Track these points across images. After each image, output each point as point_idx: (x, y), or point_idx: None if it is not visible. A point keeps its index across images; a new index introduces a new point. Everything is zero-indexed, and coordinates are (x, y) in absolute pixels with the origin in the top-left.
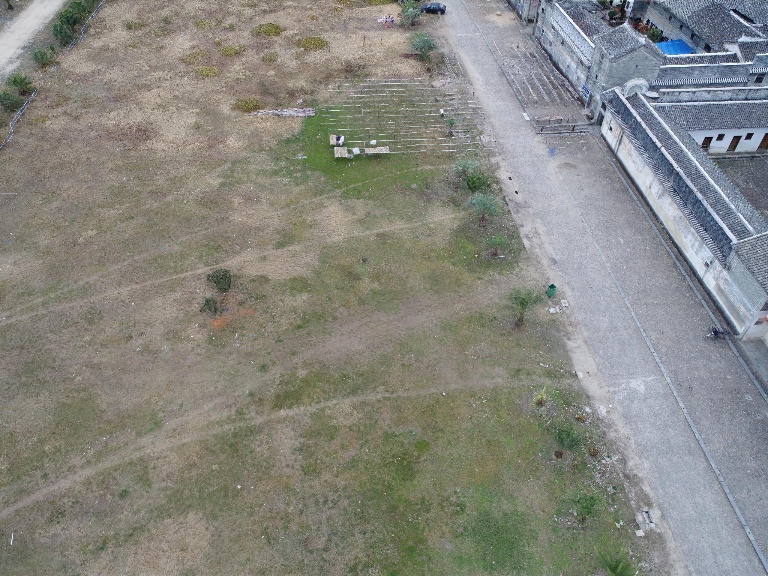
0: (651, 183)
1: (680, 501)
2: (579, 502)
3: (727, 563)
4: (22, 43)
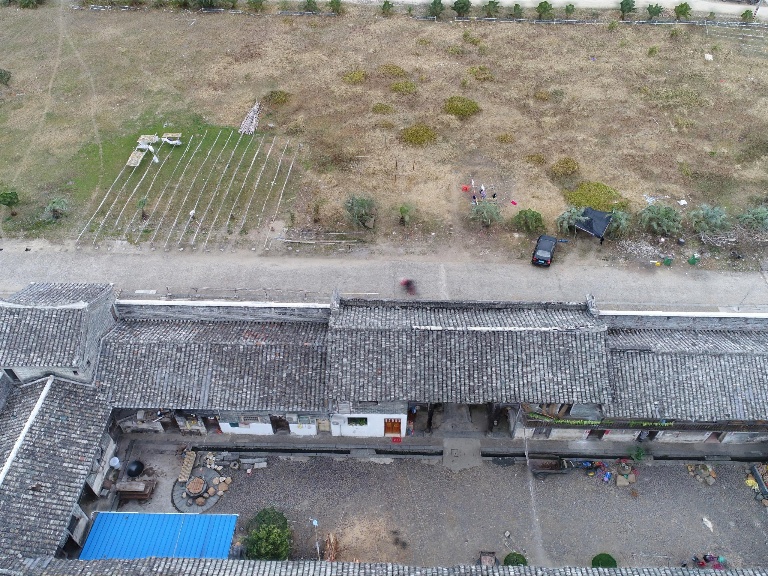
0: None
1: None
2: None
3: None
4: None
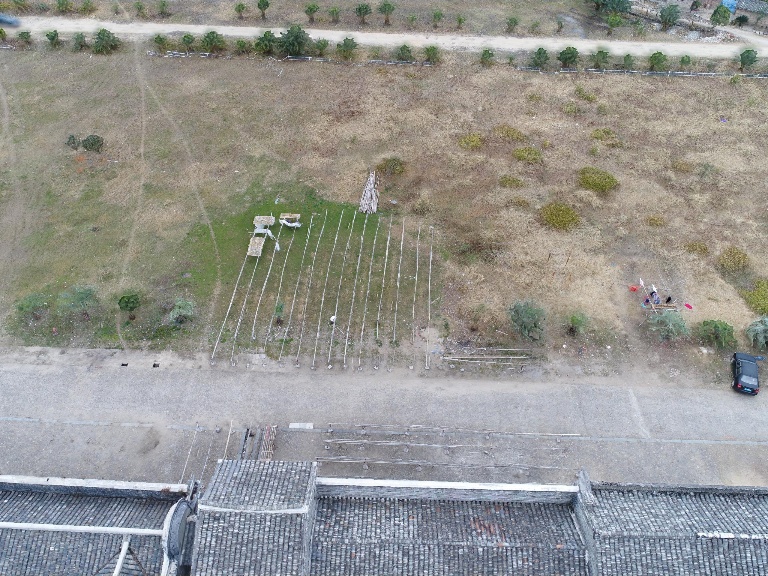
0: None
1: None
2: None
3: None
4: (530, 49)
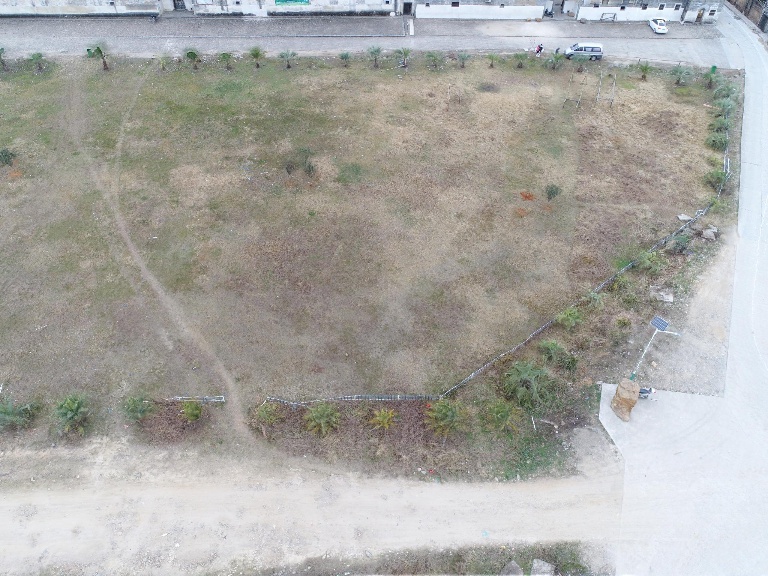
0: (32, 2)
1: (232, 47)
2: (224, 56)
3: (261, 43)
4: None
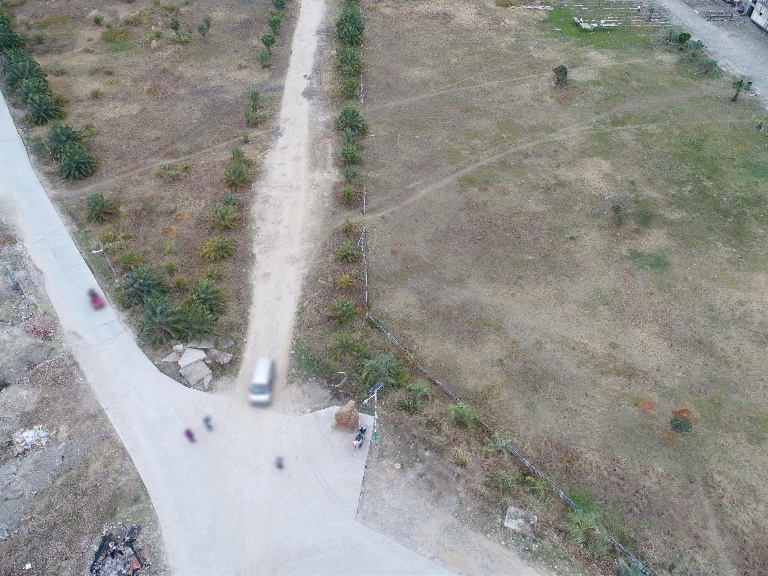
0: None
1: None
2: None
3: None
4: None
